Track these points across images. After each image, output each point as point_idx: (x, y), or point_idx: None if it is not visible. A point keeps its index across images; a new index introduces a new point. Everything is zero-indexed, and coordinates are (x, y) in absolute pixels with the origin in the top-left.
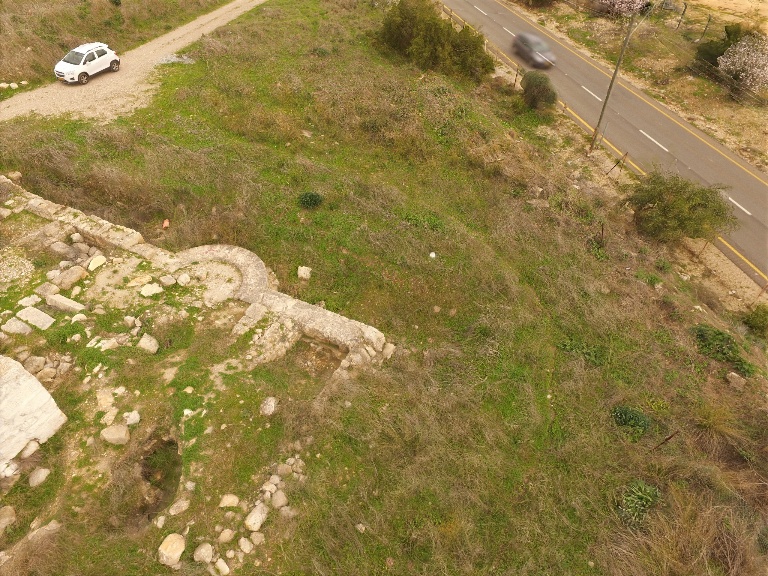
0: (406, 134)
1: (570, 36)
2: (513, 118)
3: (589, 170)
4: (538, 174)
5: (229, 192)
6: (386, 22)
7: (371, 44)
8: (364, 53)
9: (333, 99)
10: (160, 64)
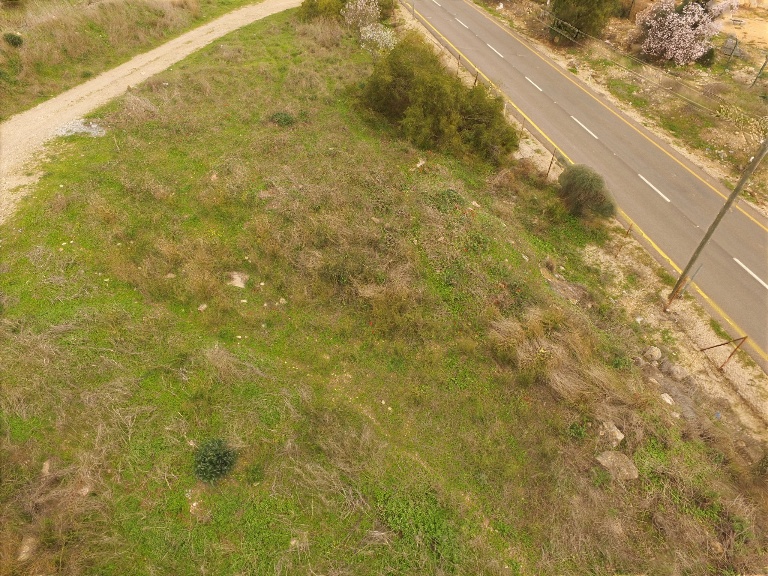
0: (391, 293)
1: (611, 91)
2: (548, 230)
3: (671, 338)
4: (612, 395)
5: (77, 431)
6: (372, 80)
7: (352, 107)
8: (342, 118)
9: (287, 210)
10: (55, 137)
